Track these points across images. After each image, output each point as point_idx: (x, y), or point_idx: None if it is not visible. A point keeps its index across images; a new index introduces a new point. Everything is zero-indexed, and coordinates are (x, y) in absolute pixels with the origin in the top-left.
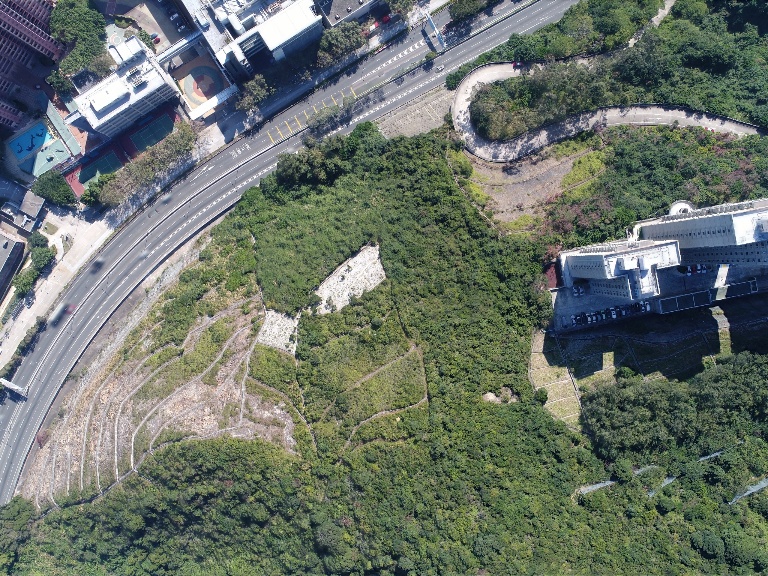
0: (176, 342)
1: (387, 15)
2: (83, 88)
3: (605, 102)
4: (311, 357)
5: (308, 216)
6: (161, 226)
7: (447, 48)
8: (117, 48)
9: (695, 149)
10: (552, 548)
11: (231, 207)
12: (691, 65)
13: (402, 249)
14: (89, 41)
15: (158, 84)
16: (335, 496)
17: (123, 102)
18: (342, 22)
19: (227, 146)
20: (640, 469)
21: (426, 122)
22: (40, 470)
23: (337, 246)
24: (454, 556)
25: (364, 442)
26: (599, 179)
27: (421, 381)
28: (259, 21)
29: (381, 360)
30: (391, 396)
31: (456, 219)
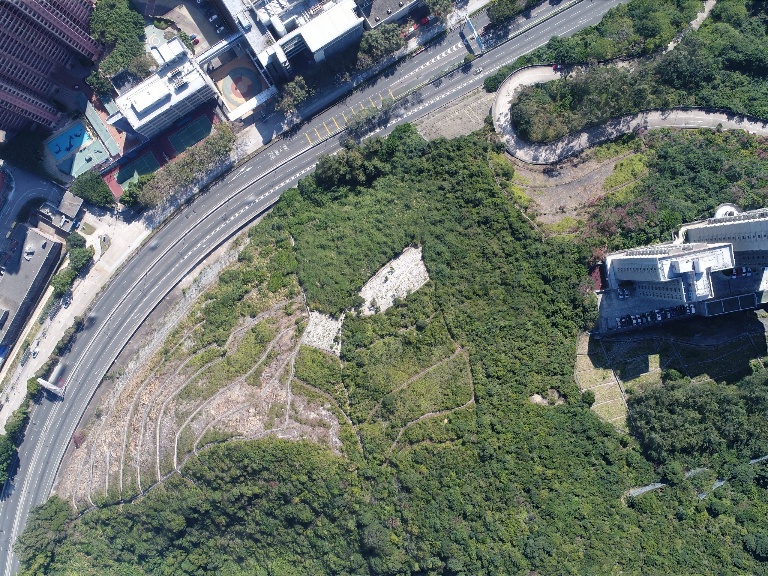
0: (219, 343)
1: (426, 17)
2: (122, 89)
3: (648, 105)
4: (356, 358)
5: (348, 217)
6: (199, 227)
7: (485, 50)
8: (159, 49)
9: (737, 152)
10: (603, 550)
11: (269, 208)
12: (732, 68)
13: (445, 251)
14: (129, 42)
15: (199, 85)
16: (382, 497)
17: (164, 103)
18: (382, 24)
19: (265, 147)
20: (690, 471)
21: (466, 124)
22: (77, 470)
23: (379, 247)
24: (505, 558)
25: (411, 443)
26: (642, 182)
27: (468, 383)
28: (301, 23)
29: (427, 362)
30: (438, 398)
31: (499, 221)
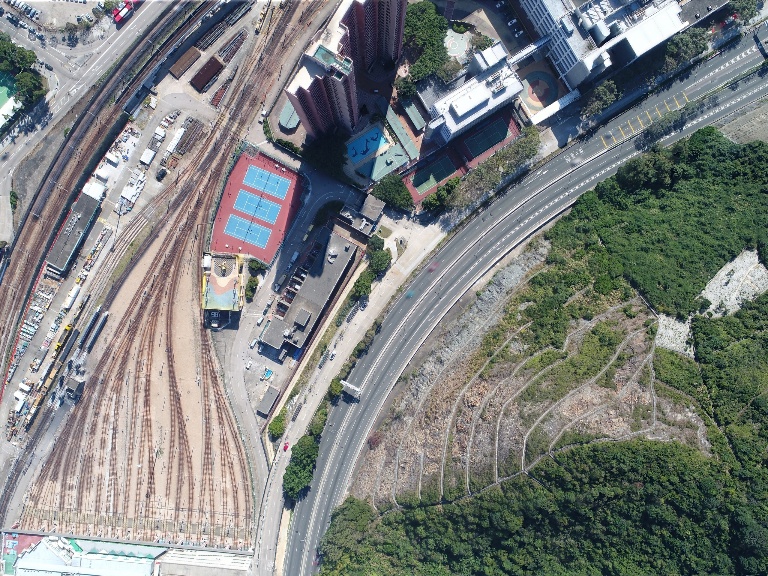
0: (559, 345)
1: (723, 21)
2: (424, 93)
3: None
4: (715, 360)
5: (663, 220)
6: (494, 230)
7: None
8: (483, 54)
9: None
10: None
11: (563, 211)
12: None
13: None
14: (436, 46)
15: (516, 89)
16: (764, 498)
17: (481, 107)
18: (690, 28)
19: (562, 150)
20: None
21: None
22: (376, 471)
23: (714, 250)
24: None
25: None
26: None
27: None
28: (622, 27)
29: None
30: None
31: None
